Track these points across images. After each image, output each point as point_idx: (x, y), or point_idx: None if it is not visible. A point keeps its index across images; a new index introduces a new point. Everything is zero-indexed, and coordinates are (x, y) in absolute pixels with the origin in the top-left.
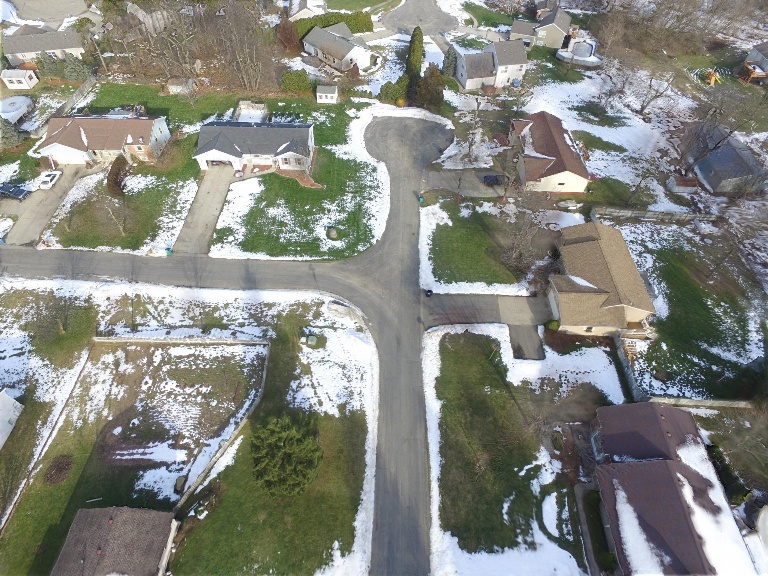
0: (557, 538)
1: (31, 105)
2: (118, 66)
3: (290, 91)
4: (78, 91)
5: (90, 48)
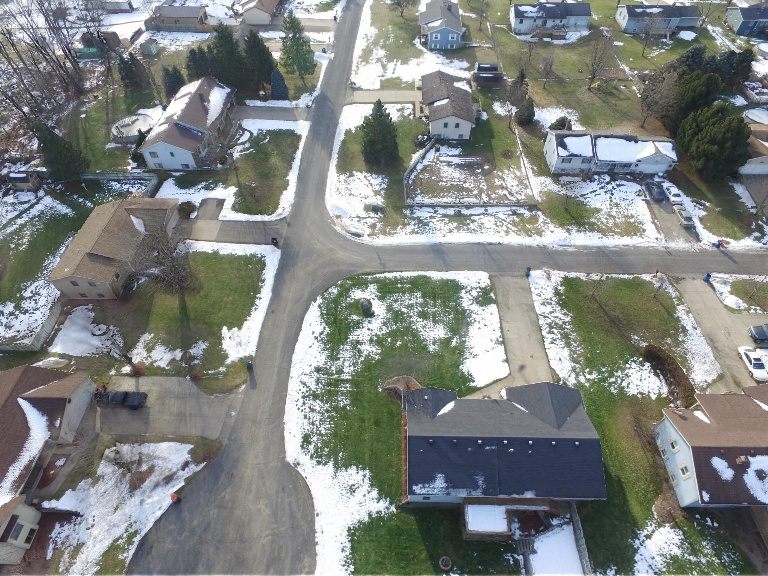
0: (247, 131)
1: None
2: None
3: None
4: None
5: None
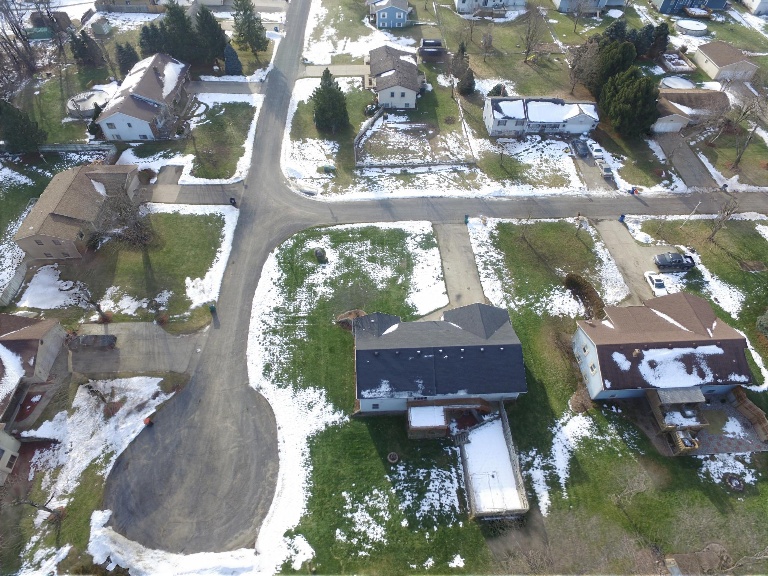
0: (202, 104)
1: None
2: None
3: None
4: None
5: None
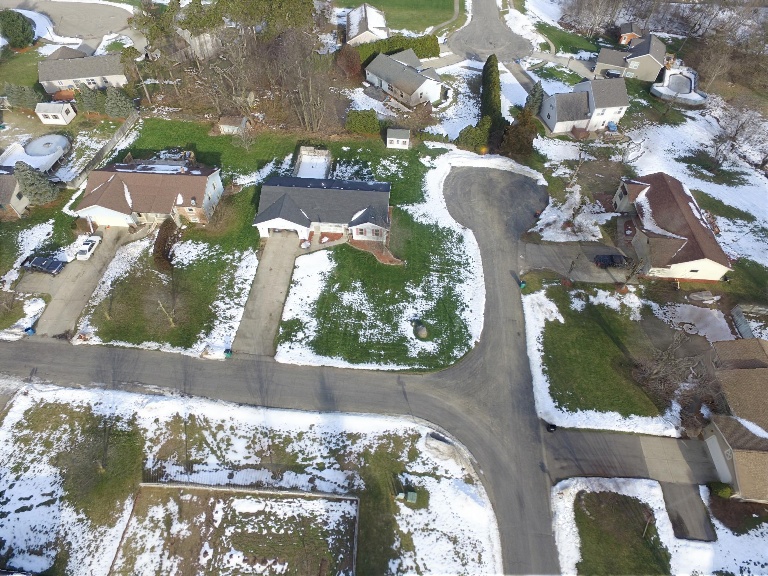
0: None
1: (67, 146)
2: (162, 97)
3: (355, 133)
4: (119, 130)
5: (132, 74)
